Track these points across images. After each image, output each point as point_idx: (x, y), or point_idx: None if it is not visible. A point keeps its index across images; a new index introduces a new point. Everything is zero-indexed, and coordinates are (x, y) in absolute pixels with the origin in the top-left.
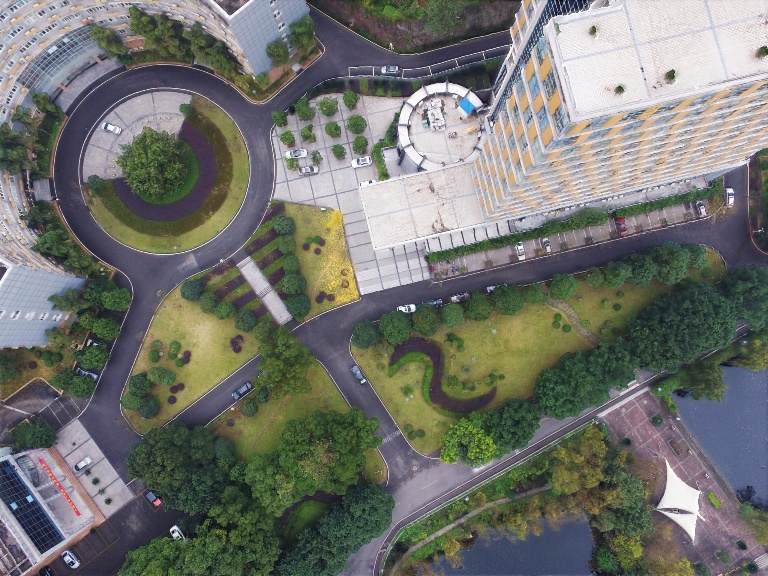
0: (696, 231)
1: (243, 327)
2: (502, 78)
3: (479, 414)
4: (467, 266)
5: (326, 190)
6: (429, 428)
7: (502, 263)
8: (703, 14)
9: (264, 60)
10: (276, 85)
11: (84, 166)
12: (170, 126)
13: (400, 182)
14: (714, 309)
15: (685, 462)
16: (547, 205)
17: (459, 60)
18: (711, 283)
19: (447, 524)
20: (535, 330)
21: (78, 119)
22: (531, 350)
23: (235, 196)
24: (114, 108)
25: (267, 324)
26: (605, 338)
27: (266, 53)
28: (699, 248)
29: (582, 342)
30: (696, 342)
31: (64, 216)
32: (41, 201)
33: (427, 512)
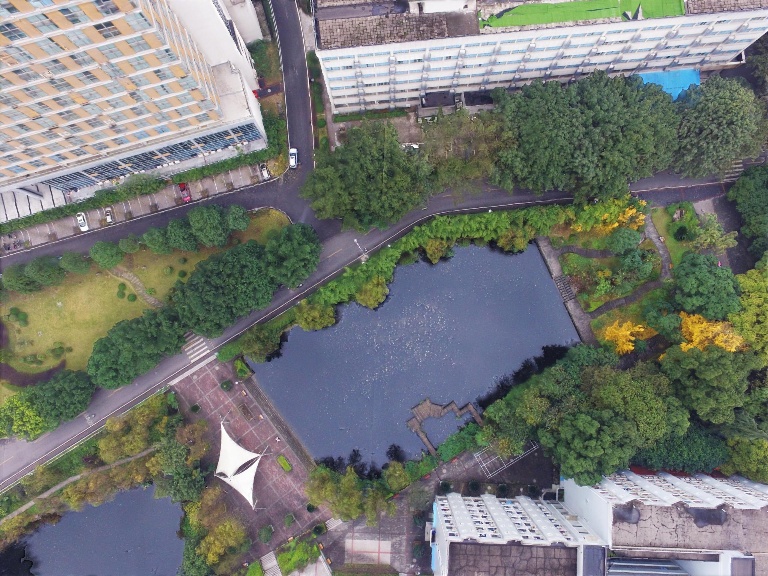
0: (263, 194)
1: None
2: None
3: (33, 387)
4: (31, 240)
5: None
6: (1, 404)
7: (66, 235)
8: None
9: None
10: None
11: None
12: None
13: None
14: (242, 269)
15: (257, 427)
16: (23, 170)
17: None
18: None
19: (29, 500)
20: (101, 301)
21: None
22: (98, 321)
23: None
24: None
25: None
26: None
27: None
28: (231, 209)
29: None
30: (219, 303)
31: None
32: None
33: (3, 489)
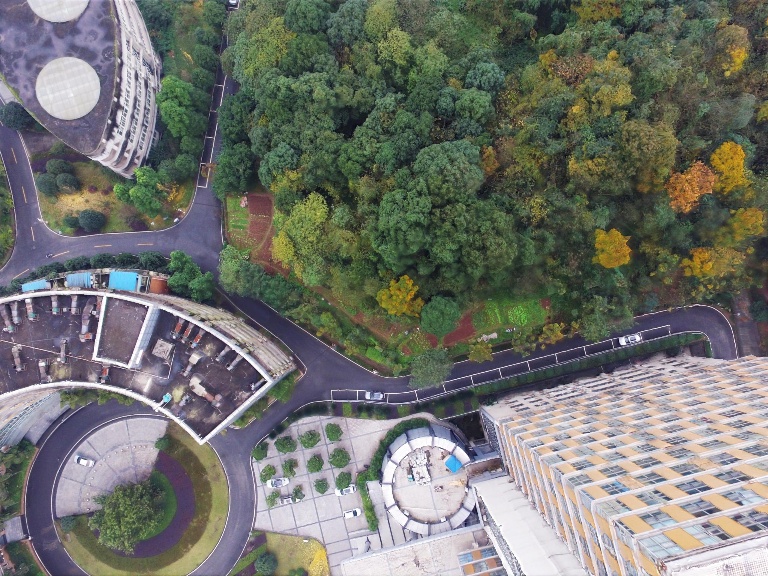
0: None
1: None
2: (490, 425)
3: None
4: None
5: (309, 518)
6: None
7: None
8: None
9: None
10: None
11: (57, 500)
12: (146, 455)
13: (384, 556)
14: None
15: None
16: None
17: (446, 384)
18: None
19: None
20: None
21: (49, 451)
22: None
23: (215, 527)
24: (87, 438)
25: None
26: None
27: None
28: None
29: None
30: None
31: (37, 553)
32: (12, 546)
33: None
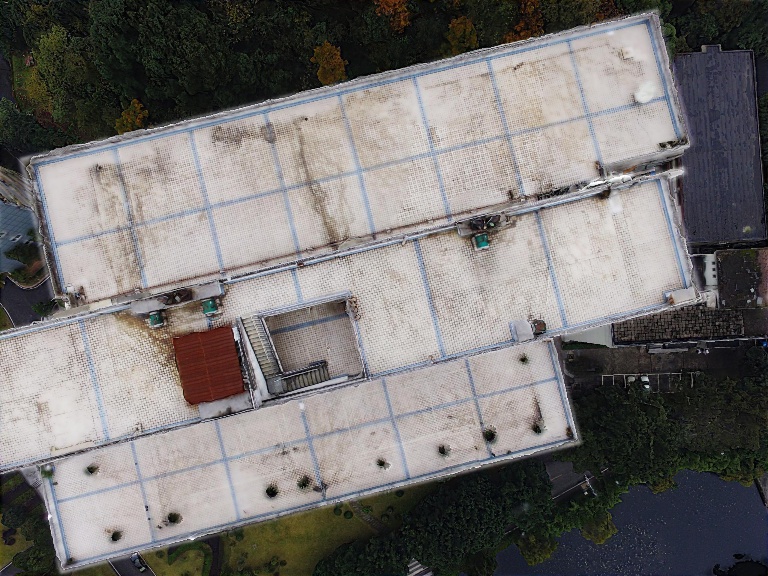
0: None
1: (9, 526)
2: None
3: None
4: None
5: None
6: None
7: None
8: (215, 445)
9: (12, 262)
10: (46, 269)
11: None
12: None
13: None
14: (479, 513)
15: None
16: None
17: None
18: (497, 468)
19: None
20: (316, 517)
21: None
22: (313, 536)
23: None
24: None
25: (35, 521)
26: (389, 523)
27: (9, 259)
28: None
29: (365, 527)
30: (458, 549)
31: None
32: None
33: None
